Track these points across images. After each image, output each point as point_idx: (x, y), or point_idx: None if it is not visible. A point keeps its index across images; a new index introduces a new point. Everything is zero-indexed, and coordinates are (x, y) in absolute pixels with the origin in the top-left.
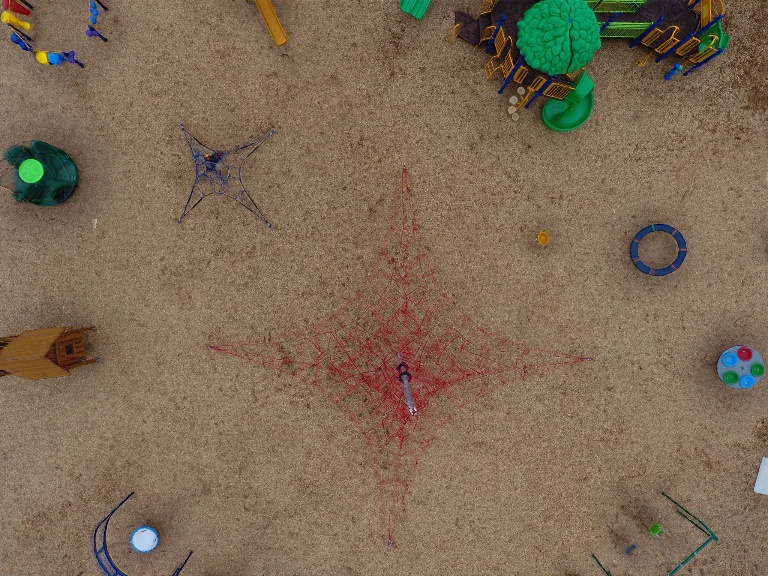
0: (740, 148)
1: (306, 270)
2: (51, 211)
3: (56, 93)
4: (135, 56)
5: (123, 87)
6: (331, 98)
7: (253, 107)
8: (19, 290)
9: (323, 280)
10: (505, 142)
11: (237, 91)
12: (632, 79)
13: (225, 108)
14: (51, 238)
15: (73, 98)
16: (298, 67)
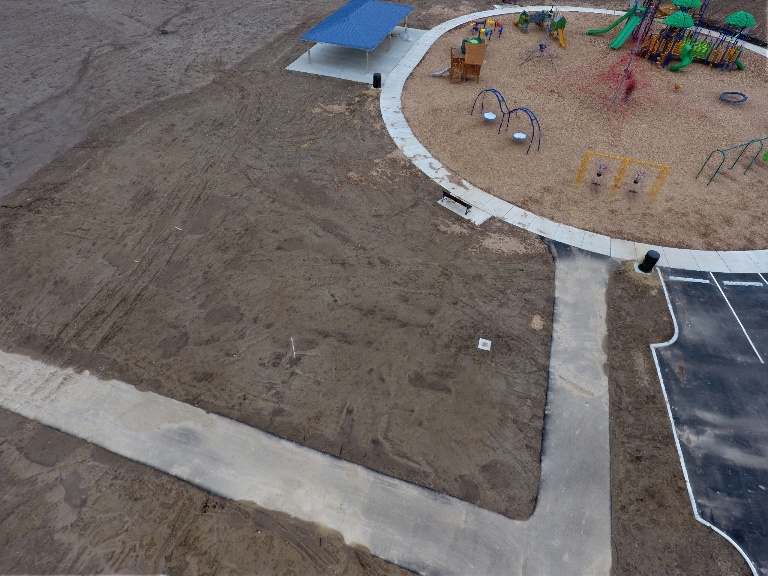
0: (763, 88)
1: None
2: None
3: None
4: None
5: None
6: None
7: None
8: None
9: None
10: (655, 72)
11: None
12: (707, 70)
13: None
14: None
15: None
16: (569, 51)
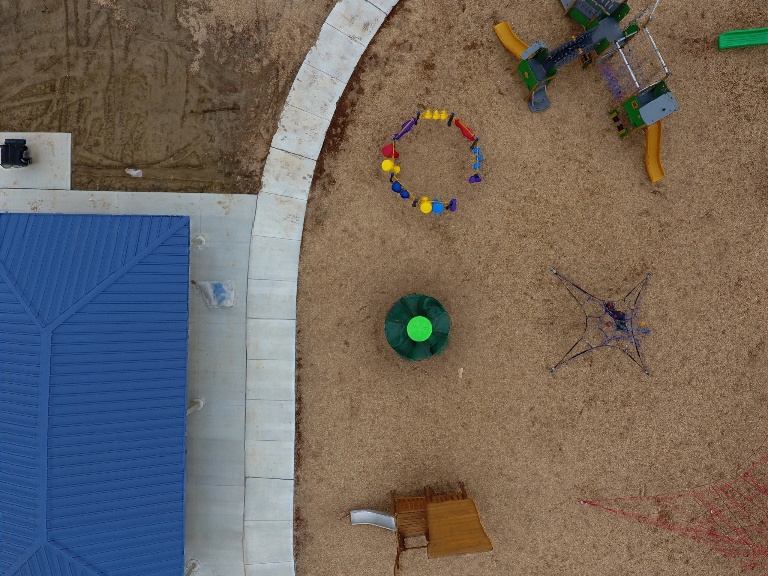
0: None
1: (684, 419)
2: (413, 360)
3: (419, 236)
4: (501, 196)
5: (489, 229)
6: (707, 237)
7: (626, 248)
8: (381, 445)
9: (701, 429)
10: None
11: (609, 231)
12: None
13: (597, 249)
14: (414, 389)
15: (437, 241)
16: (672, 204)
